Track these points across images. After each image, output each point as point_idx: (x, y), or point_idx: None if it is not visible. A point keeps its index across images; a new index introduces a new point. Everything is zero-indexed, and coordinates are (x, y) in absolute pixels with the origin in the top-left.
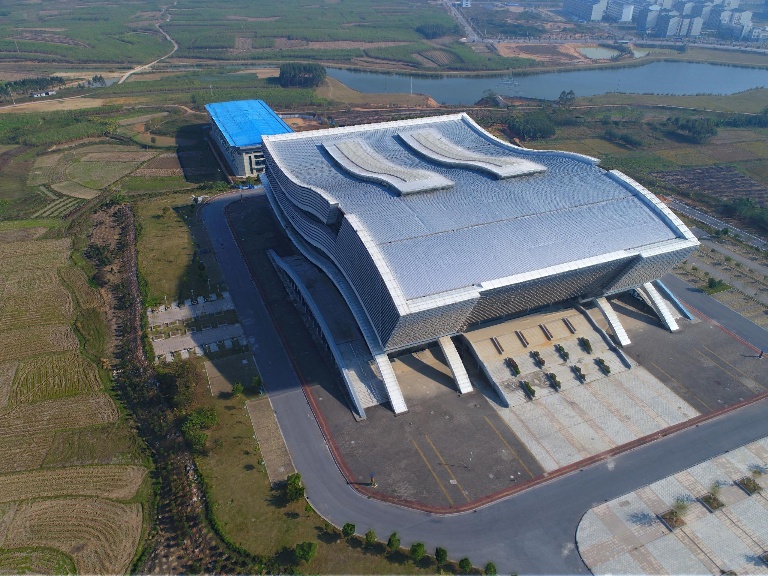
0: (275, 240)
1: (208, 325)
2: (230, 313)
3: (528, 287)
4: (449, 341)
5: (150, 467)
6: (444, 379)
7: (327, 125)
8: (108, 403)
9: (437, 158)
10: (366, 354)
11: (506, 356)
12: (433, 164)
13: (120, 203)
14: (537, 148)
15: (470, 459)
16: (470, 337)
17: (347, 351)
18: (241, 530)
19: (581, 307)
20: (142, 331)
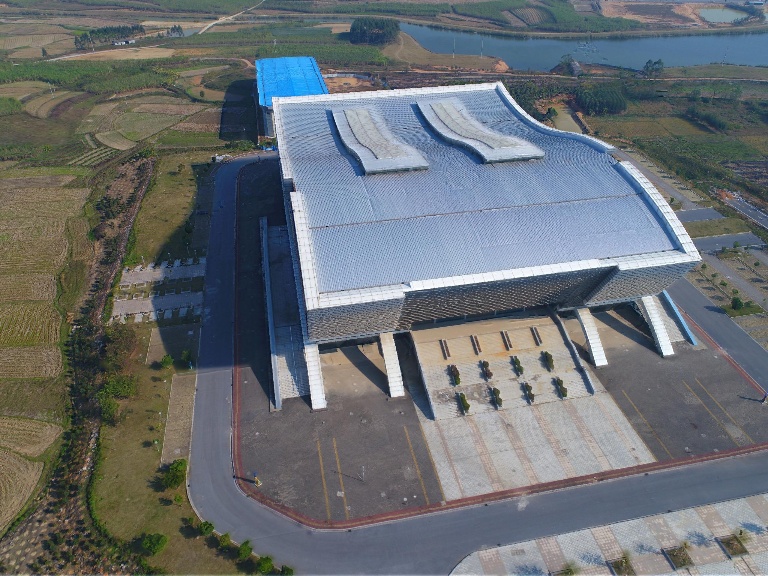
0: (273, 207)
1: (172, 290)
2: (198, 280)
3: (472, 291)
4: (390, 338)
5: (66, 427)
6: (379, 378)
7: (379, 87)
8: (57, 357)
9: (443, 133)
10: None
11: (451, 362)
12: (438, 139)
13: (147, 157)
14: (600, 124)
15: None
16: (418, 336)
17: (285, 335)
18: (112, 508)
19: (557, 316)
20: (110, 289)
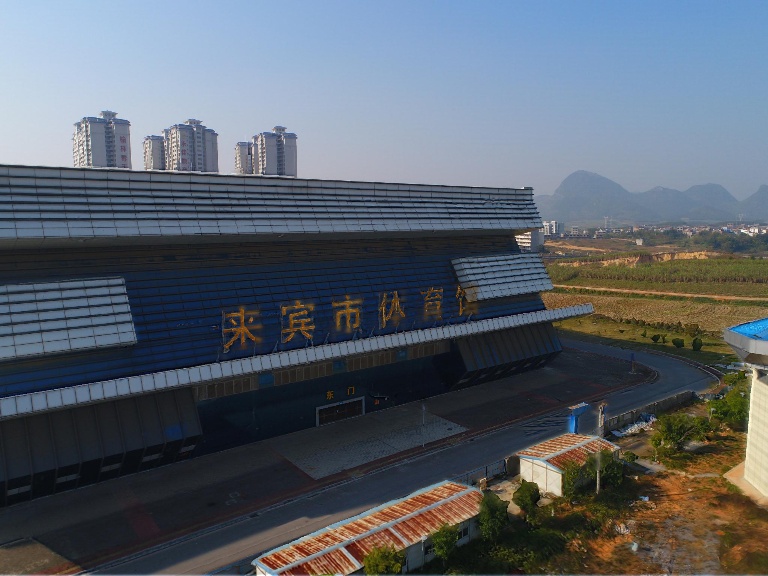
0: None
1: None
2: None
3: None
4: None
5: None
6: None
7: None
8: None
9: None
10: None
11: None
12: None
13: None
14: None
15: None
16: None
17: None
18: None
19: None
20: None
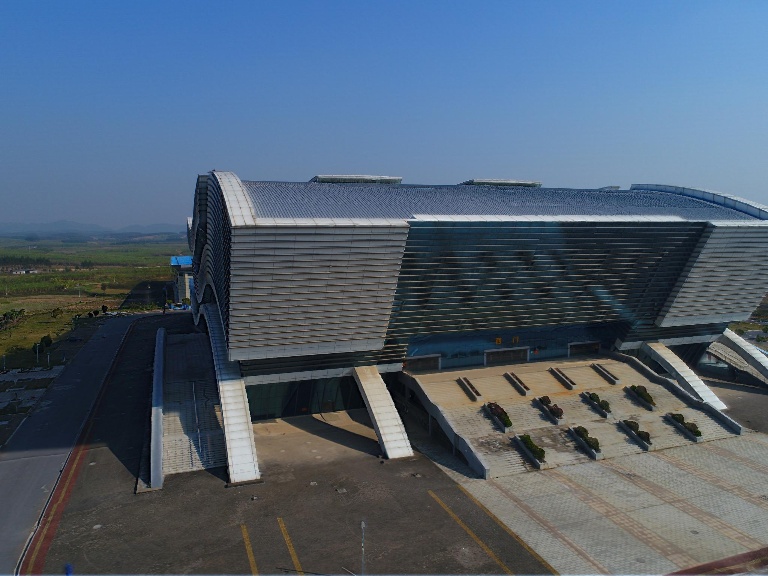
0: None
1: None
2: (43, 380)
3: (509, 248)
4: (373, 373)
5: None
6: (359, 441)
7: None
8: None
9: None
10: (216, 397)
11: None
12: None
13: (14, 317)
14: None
15: (363, 549)
16: None
17: (181, 391)
18: None
19: (622, 354)
20: None
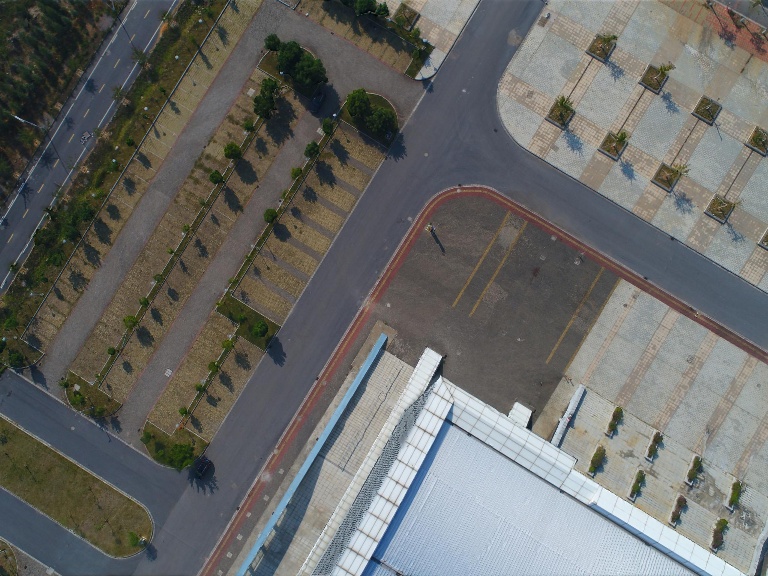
0: None
1: None
2: None
3: None
4: None
5: None
6: None
7: None
8: None
9: None
10: None
11: None
12: None
13: None
14: None
15: None
16: None
17: None
18: None
19: None
20: None
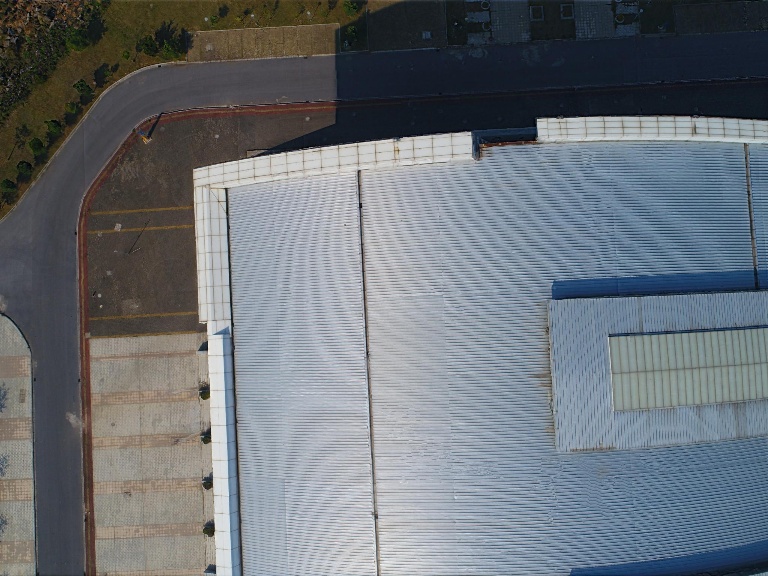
0: None
1: None
2: (563, 29)
3: None
4: None
5: None
6: None
7: None
8: None
9: None
10: None
11: None
12: None
13: None
14: None
15: None
16: None
17: None
18: None
19: None
20: None
